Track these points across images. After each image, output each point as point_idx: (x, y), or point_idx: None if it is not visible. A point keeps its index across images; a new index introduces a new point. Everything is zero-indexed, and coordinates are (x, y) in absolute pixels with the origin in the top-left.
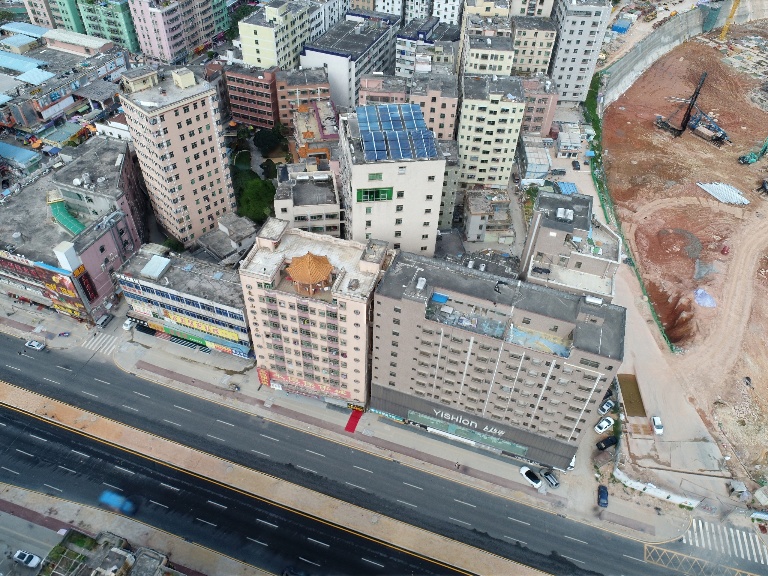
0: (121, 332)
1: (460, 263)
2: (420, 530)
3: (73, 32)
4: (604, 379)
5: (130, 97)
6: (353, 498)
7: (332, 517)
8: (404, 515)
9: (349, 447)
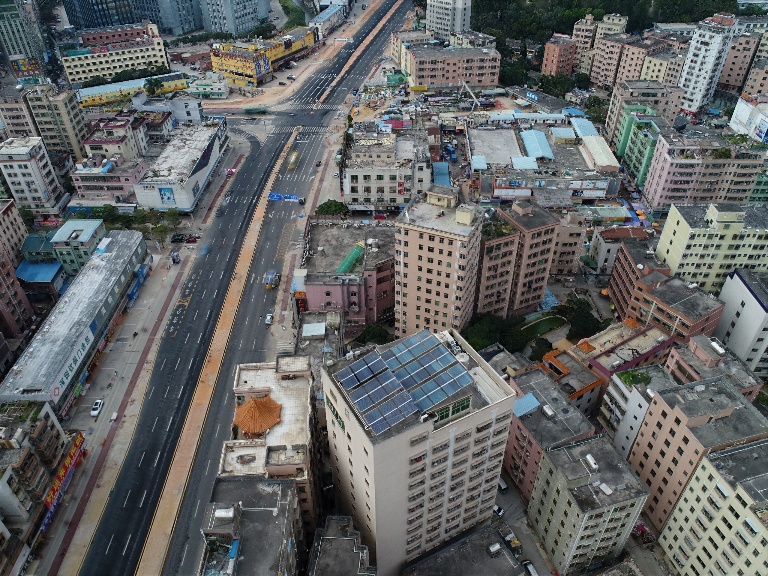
0: None
1: (361, 570)
2: None
3: (606, 145)
4: None
5: (418, 204)
6: None
7: None
8: None
9: None
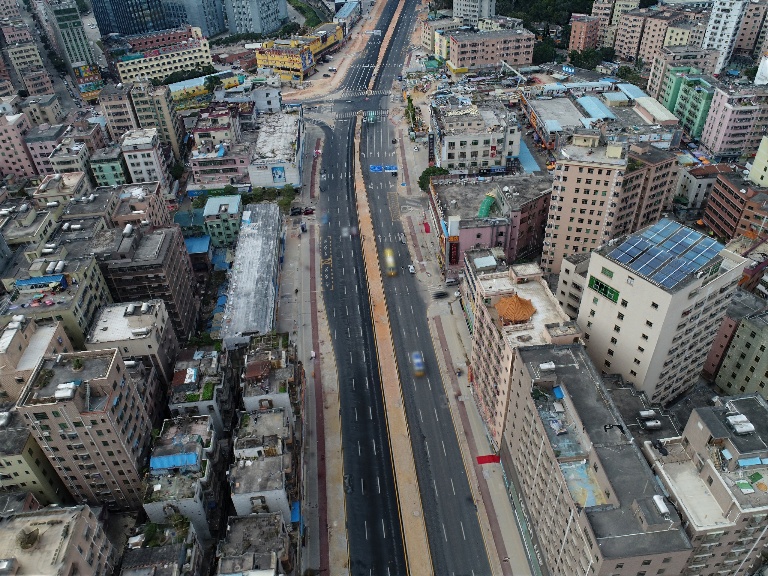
0: (452, 295)
1: (646, 407)
2: (428, 552)
3: (659, 103)
4: (593, 569)
5: (566, 146)
6: (425, 491)
7: (401, 484)
8: (433, 534)
9: (465, 468)
